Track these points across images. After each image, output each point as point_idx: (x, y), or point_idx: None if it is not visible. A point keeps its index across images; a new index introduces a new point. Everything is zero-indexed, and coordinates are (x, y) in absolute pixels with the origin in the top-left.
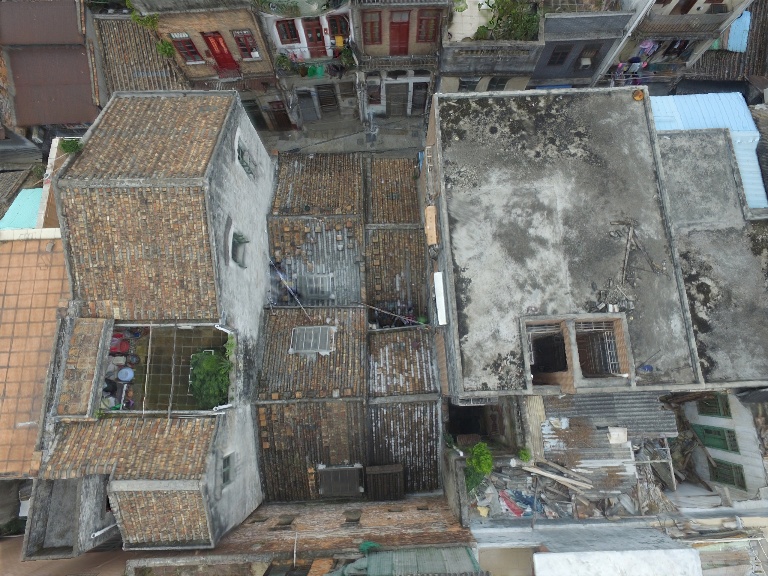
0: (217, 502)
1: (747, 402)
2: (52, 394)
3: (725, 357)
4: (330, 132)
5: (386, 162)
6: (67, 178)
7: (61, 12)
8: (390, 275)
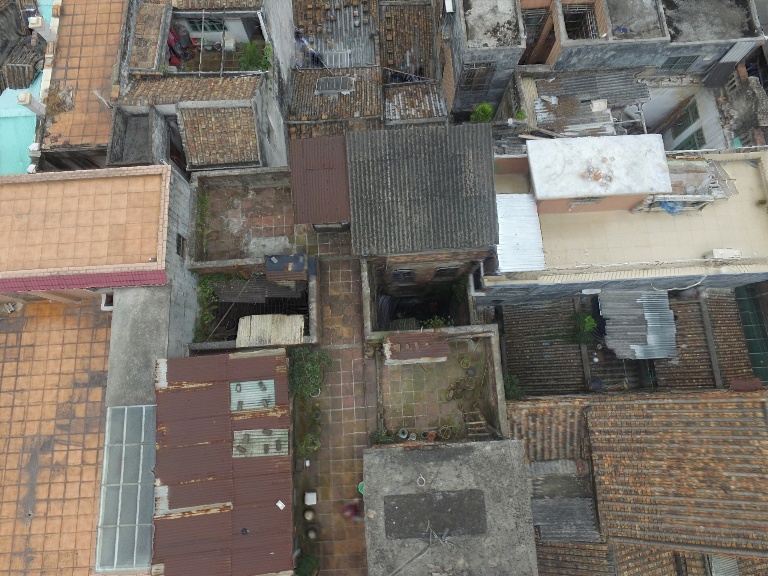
0: (263, 137)
1: (711, 87)
2: (125, 50)
3: (689, 27)
4: None
5: None
6: None
7: None
8: (401, 51)
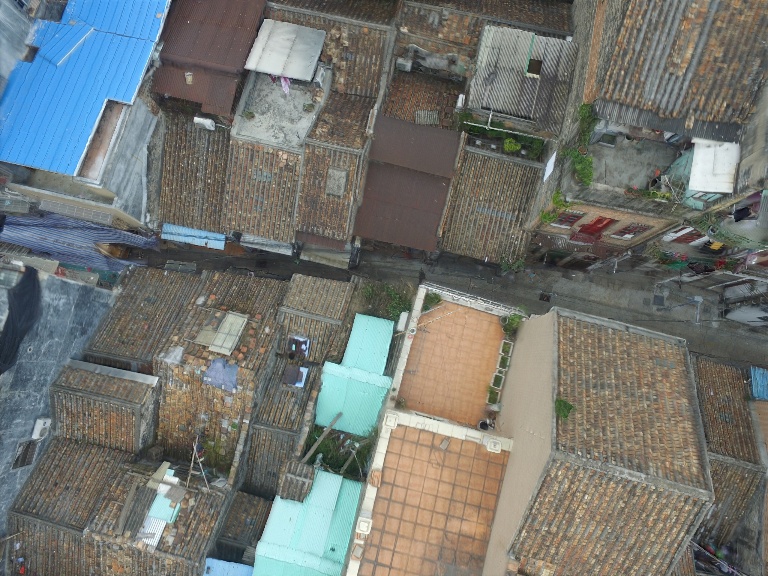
0: None
1: None
2: None
3: None
4: (617, 283)
5: (712, 366)
6: (561, 449)
7: (441, 142)
8: None
